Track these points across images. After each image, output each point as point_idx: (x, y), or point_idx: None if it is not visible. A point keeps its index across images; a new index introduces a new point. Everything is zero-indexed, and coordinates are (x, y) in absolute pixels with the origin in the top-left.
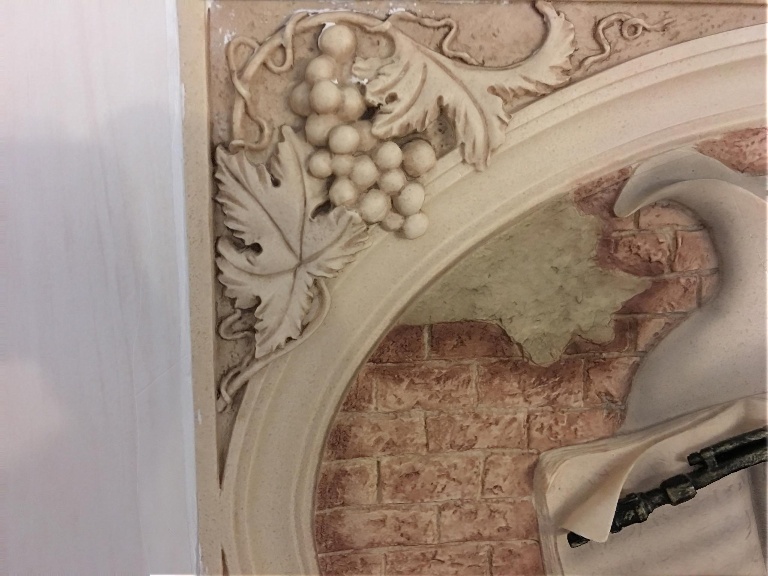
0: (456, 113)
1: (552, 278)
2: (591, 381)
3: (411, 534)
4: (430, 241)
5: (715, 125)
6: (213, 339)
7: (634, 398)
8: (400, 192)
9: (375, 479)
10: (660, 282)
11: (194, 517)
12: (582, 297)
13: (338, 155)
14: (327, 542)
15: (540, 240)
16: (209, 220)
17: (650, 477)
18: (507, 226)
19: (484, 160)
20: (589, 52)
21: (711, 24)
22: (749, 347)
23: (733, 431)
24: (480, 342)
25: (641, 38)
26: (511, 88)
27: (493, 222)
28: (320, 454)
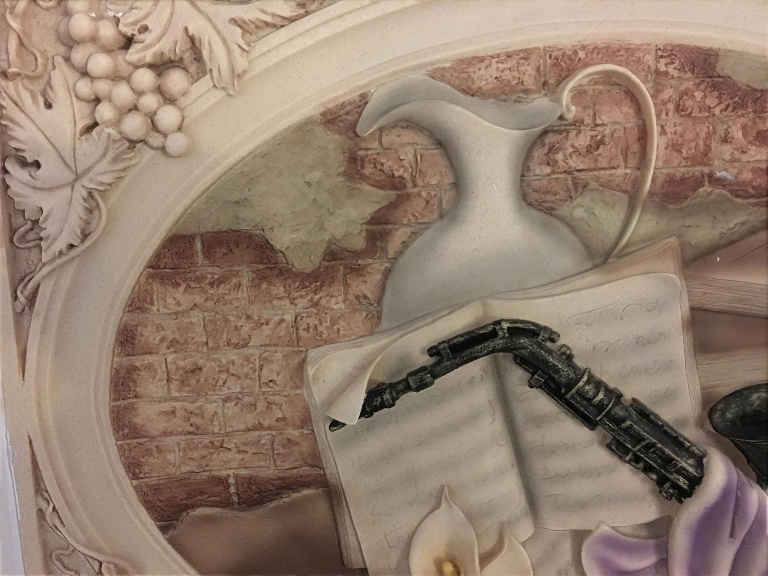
0: (201, 42)
1: (306, 192)
2: (349, 285)
3: (199, 424)
4: (197, 160)
5: (443, 53)
6: (6, 246)
7: (387, 300)
8: (155, 113)
9: (164, 374)
10: (403, 195)
11: (2, 406)
12: (333, 209)
13: (96, 79)
14: (124, 430)
15: (292, 157)
16: None
17: (400, 369)
18: None
19: (232, 85)
20: None
21: None
22: (482, 252)
23: (470, 327)
24: (247, 250)
25: None
26: (250, 20)
27: (250, 142)
28: (113, 352)
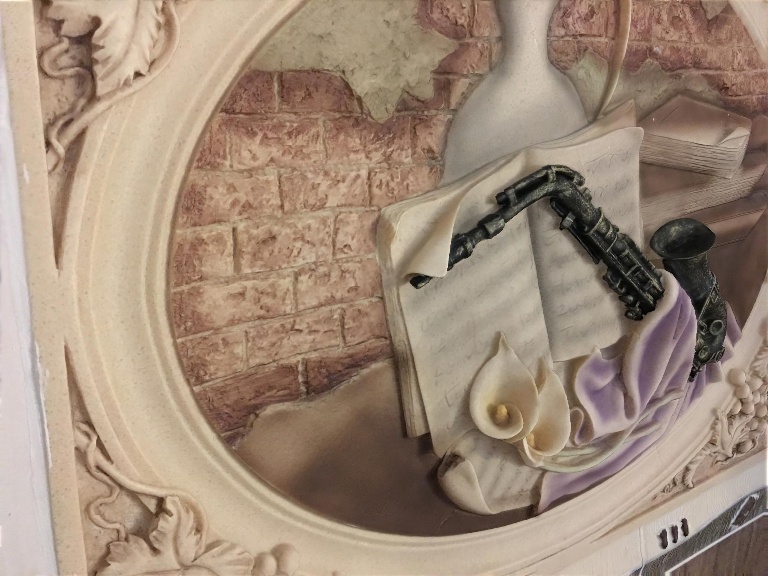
0: None
1: (385, 32)
2: (417, 137)
3: (270, 305)
4: None
5: None
6: (37, 71)
7: (450, 153)
8: None
9: (231, 249)
10: (464, 45)
11: (25, 309)
12: (409, 53)
13: None
14: (186, 324)
15: None
16: None
17: (468, 220)
18: None
19: None
20: None
21: None
22: (527, 104)
23: (521, 175)
24: (326, 95)
25: None
26: None
27: None
28: (172, 223)
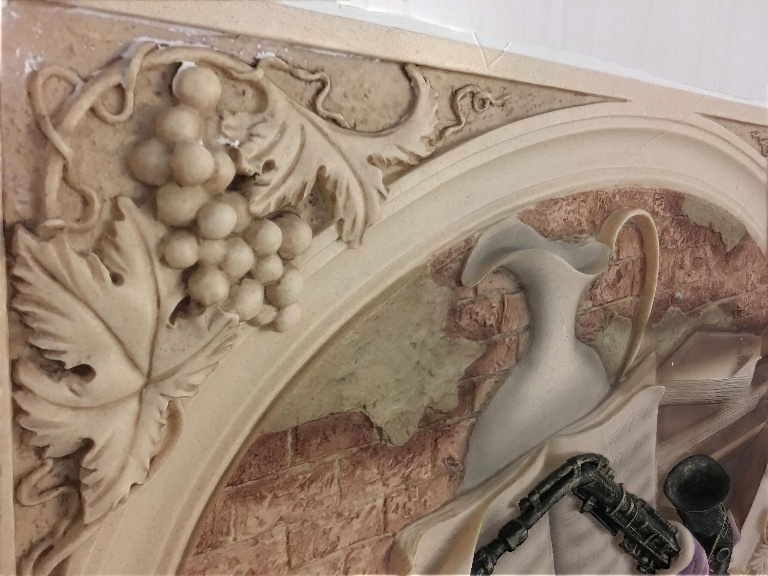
0: (337, 186)
1: (410, 354)
2: (438, 450)
3: None
4: (293, 329)
5: (532, 196)
6: (13, 513)
7: (472, 458)
8: (279, 281)
9: None
10: (492, 344)
11: None
12: (435, 370)
13: (210, 241)
14: None
15: (402, 317)
16: (6, 340)
17: (488, 529)
18: (370, 305)
19: (360, 237)
20: (447, 122)
21: (534, 103)
22: (553, 393)
23: (544, 470)
24: (344, 434)
25: (487, 112)
26: (388, 158)
27: (359, 302)
28: None
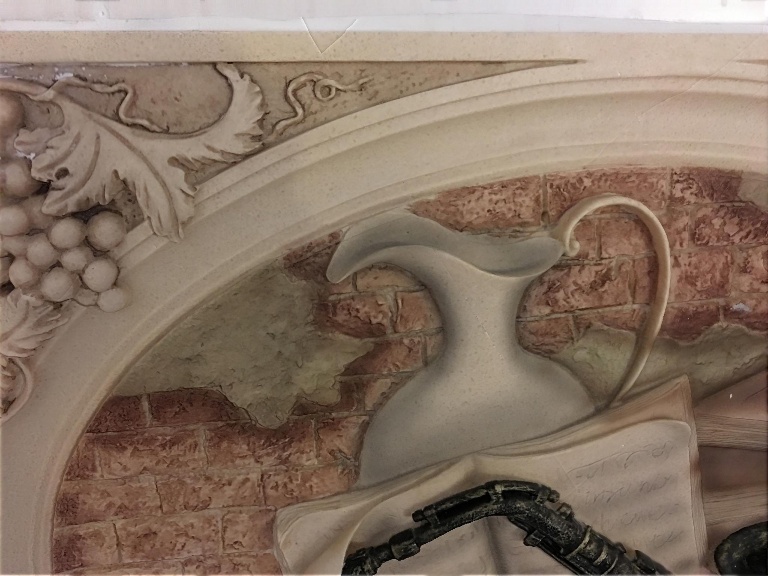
0: (136, 187)
1: (269, 344)
2: (322, 440)
3: None
4: (139, 311)
5: (427, 185)
6: None
7: (366, 455)
8: (84, 271)
9: (113, 540)
10: (383, 344)
11: None
12: (302, 362)
13: (7, 237)
14: None
15: (251, 308)
16: None
17: (382, 531)
18: (218, 294)
19: (176, 232)
20: (282, 115)
21: (412, 82)
22: (473, 406)
23: (460, 486)
24: (203, 408)
25: (337, 99)
26: (194, 158)
27: (201, 291)
28: (52, 520)
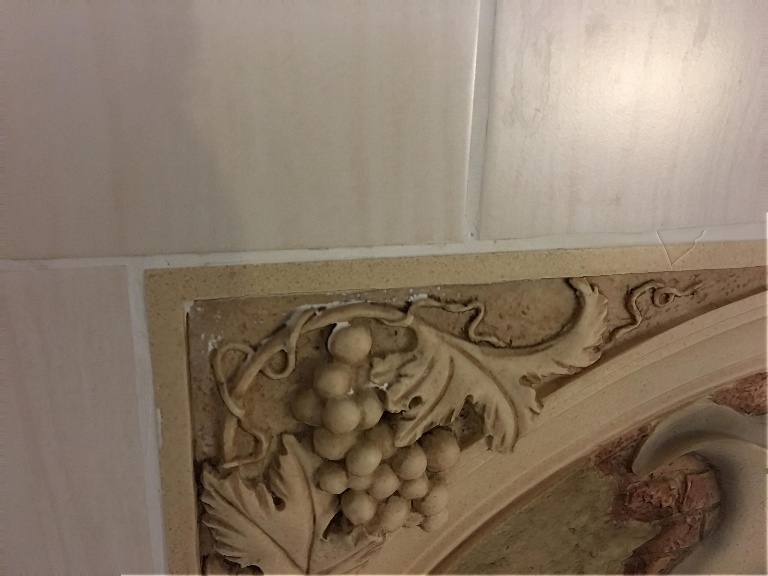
0: (486, 409)
1: (569, 539)
2: None
3: None
4: None
5: (730, 376)
6: None
7: None
8: (424, 499)
9: None
10: (669, 525)
11: None
12: (597, 552)
13: (357, 476)
14: None
15: (560, 507)
16: (196, 550)
17: None
18: (526, 495)
19: (511, 447)
20: (619, 322)
21: (737, 284)
22: (745, 575)
23: None
24: None
25: (671, 303)
26: (543, 375)
27: (512, 494)
28: None
